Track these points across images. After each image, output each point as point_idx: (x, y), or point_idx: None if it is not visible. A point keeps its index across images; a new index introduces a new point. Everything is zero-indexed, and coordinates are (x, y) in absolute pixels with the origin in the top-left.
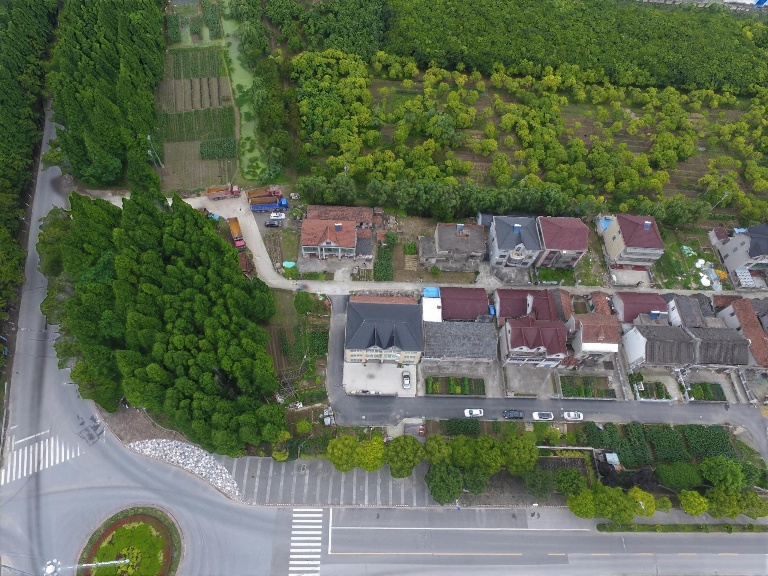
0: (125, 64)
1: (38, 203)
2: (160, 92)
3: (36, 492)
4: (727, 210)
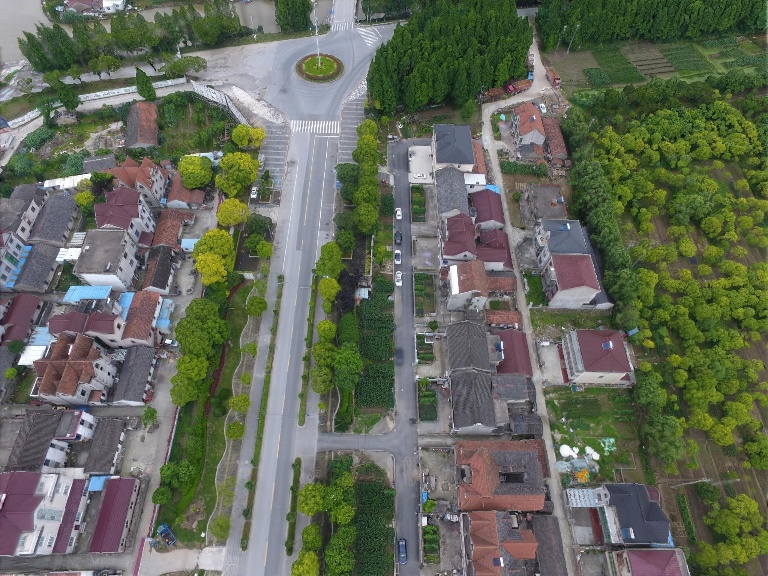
0: (641, 4)
1: (518, 11)
2: (640, 44)
3: (353, 38)
4: (708, 541)
